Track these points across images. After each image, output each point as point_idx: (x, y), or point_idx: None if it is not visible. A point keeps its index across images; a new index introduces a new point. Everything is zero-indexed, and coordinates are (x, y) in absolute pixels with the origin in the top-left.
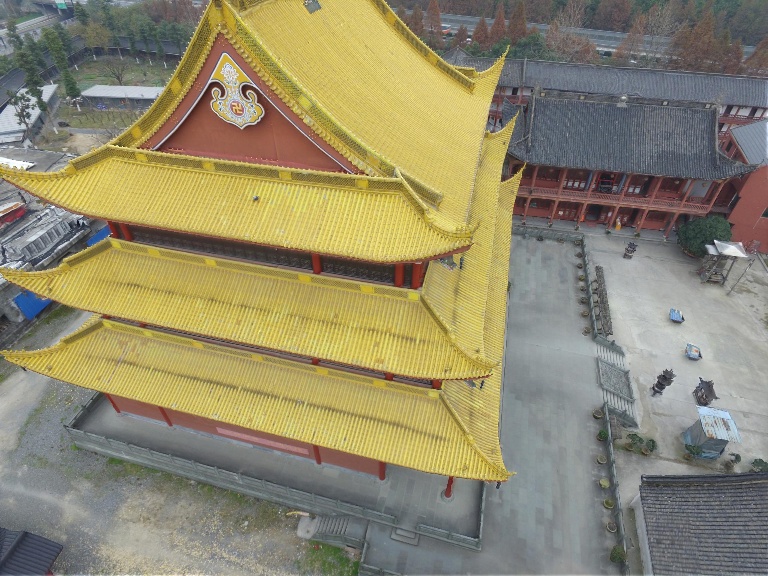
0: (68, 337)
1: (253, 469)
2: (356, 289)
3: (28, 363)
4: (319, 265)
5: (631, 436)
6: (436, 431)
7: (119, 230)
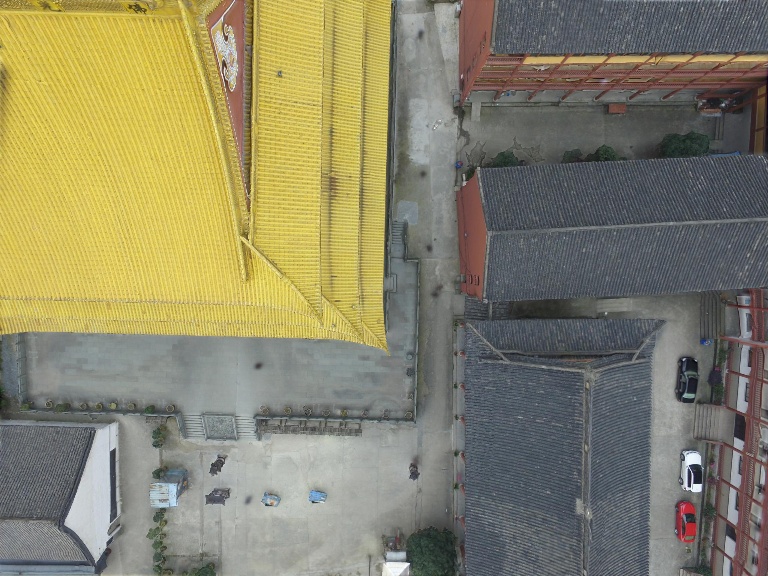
0: None
1: None
2: None
3: None
4: None
5: (155, 431)
6: None
7: None
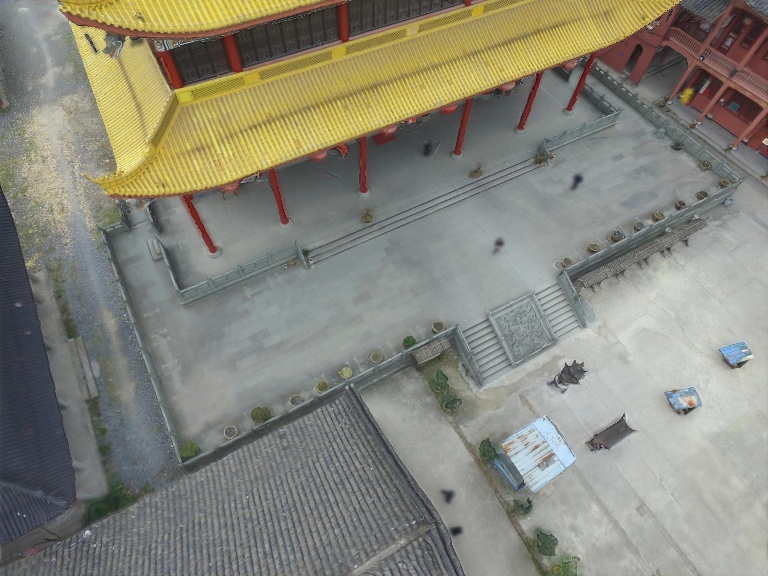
0: None
1: None
2: None
3: None
4: None
5: (438, 372)
6: None
7: None
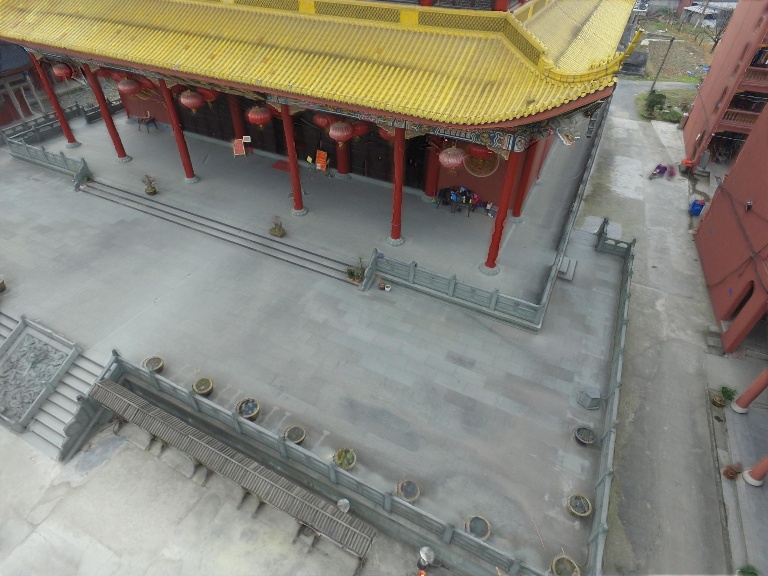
0: None
1: None
2: None
3: None
4: None
5: None
6: None
7: None
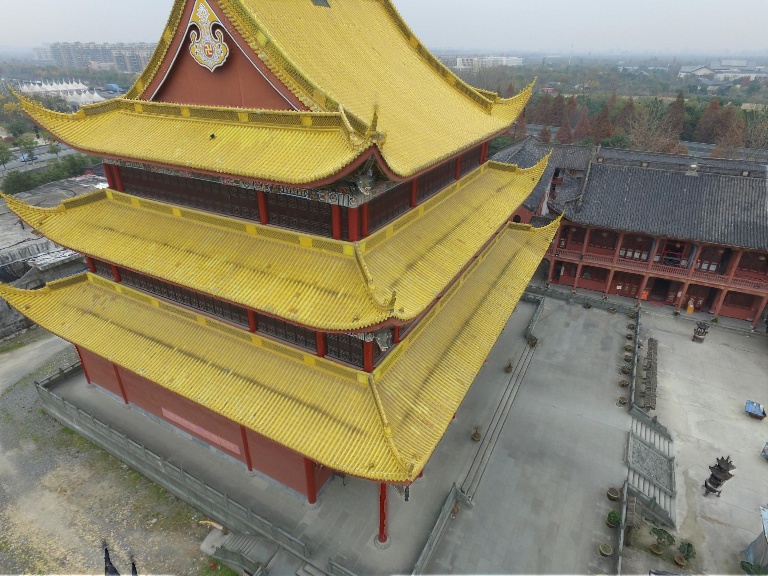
0: (54, 283)
1: (182, 461)
2: (296, 242)
3: (11, 298)
4: (265, 214)
5: (656, 530)
6: (355, 422)
7: (115, 182)
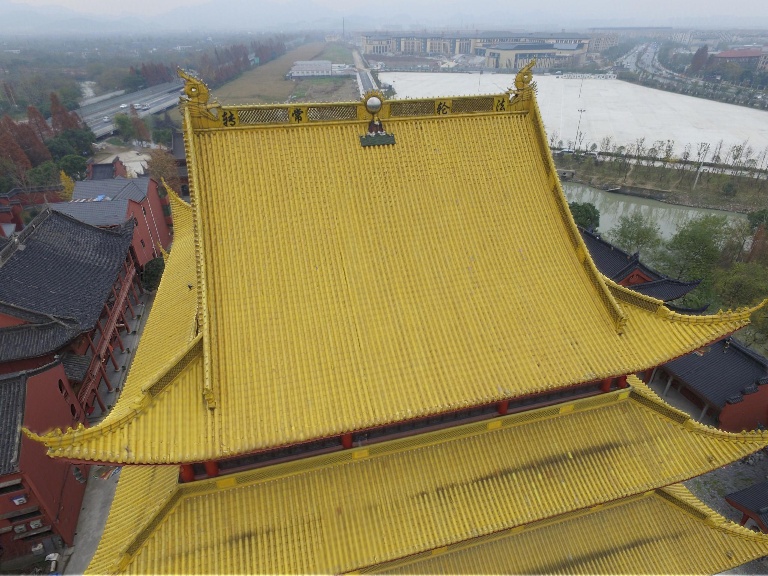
0: None
1: None
2: None
3: None
4: None
5: None
6: None
7: None
